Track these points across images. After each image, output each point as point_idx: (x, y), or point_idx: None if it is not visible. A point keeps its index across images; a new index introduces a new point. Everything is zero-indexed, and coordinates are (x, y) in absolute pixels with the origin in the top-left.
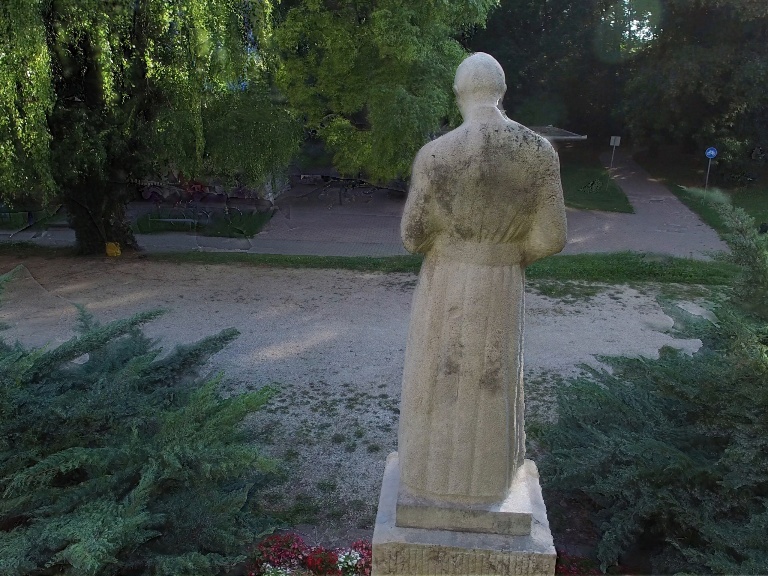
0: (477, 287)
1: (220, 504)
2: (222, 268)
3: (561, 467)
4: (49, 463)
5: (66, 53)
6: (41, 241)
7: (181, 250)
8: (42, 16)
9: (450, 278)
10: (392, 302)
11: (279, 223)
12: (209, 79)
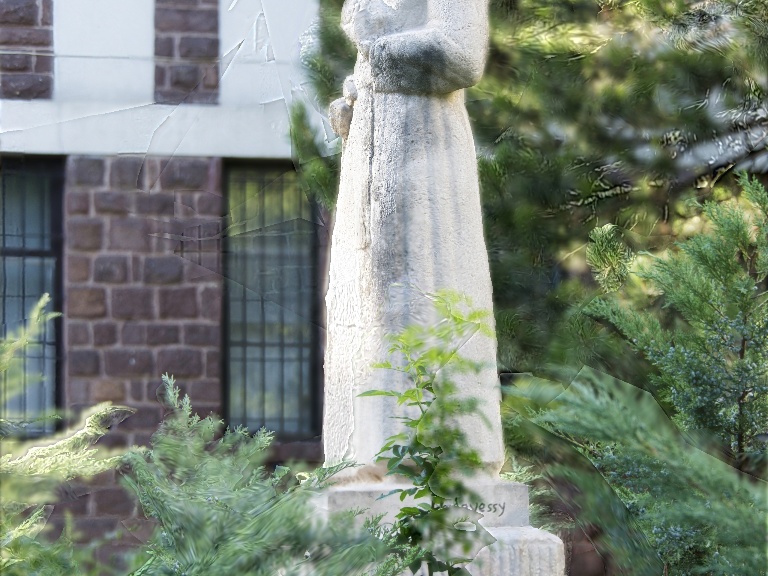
0: None
1: None
2: None
3: None
4: None
5: None
6: None
7: None
8: None
9: None
10: None
11: None
12: None
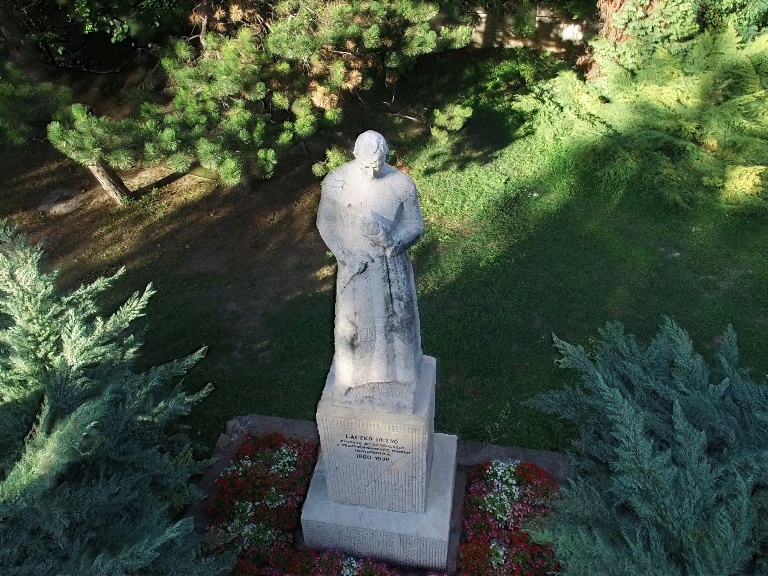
0: None
1: None
2: None
3: None
4: None
5: None
6: None
7: None
8: None
9: None
10: None
11: None
12: None
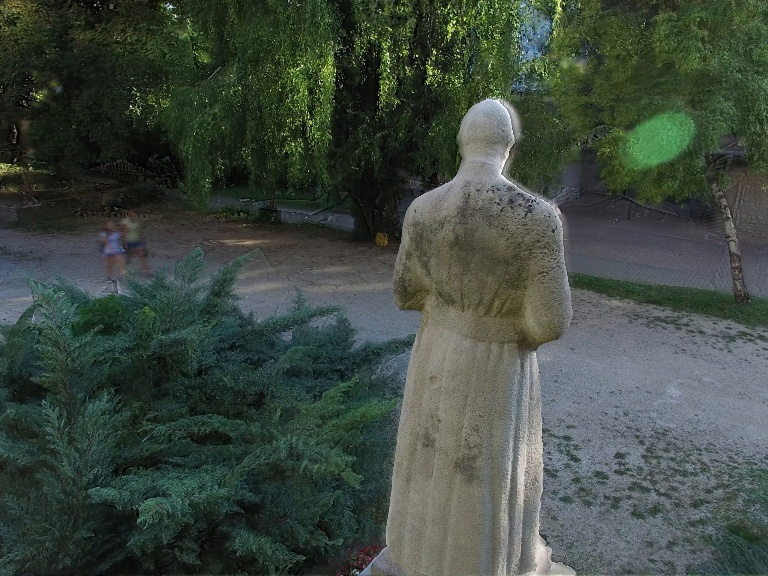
0: (456, 360)
1: (306, 501)
2: None
3: None
4: (188, 422)
5: (351, 64)
6: (329, 224)
7: None
8: (331, 32)
9: (433, 344)
10: (628, 337)
11: None
12: (485, 86)
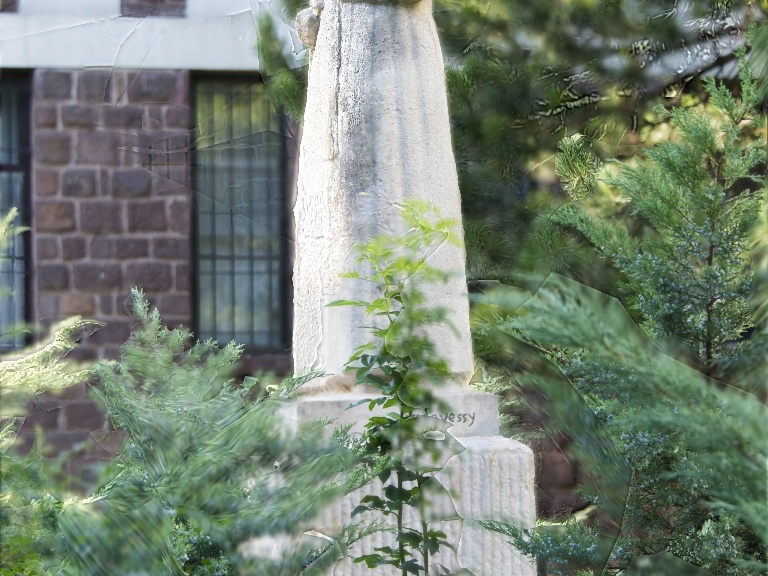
0: None
1: None
2: None
3: None
4: None
5: None
6: None
7: None
8: None
9: None
10: None
11: None
12: None
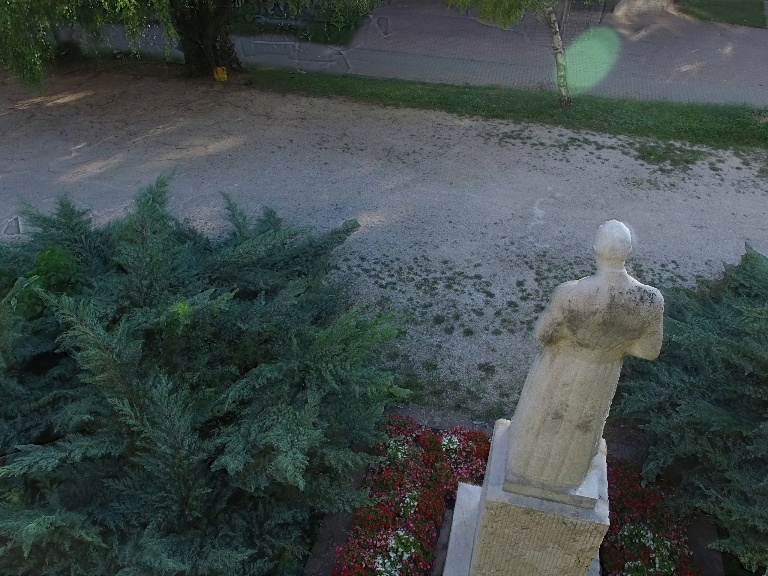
0: (585, 376)
1: (365, 415)
2: (325, 103)
3: (625, 401)
4: (247, 381)
5: None
6: None
7: (282, 73)
8: None
9: (566, 366)
10: (489, 160)
11: (373, 26)
12: None
